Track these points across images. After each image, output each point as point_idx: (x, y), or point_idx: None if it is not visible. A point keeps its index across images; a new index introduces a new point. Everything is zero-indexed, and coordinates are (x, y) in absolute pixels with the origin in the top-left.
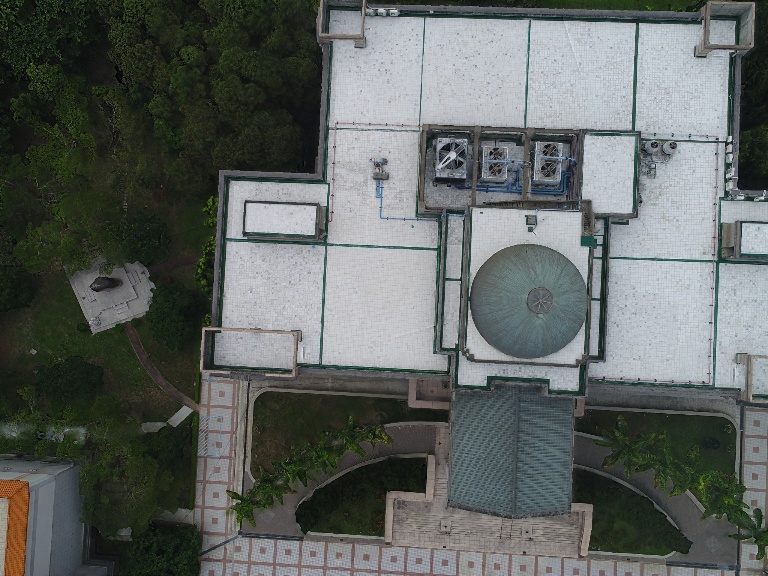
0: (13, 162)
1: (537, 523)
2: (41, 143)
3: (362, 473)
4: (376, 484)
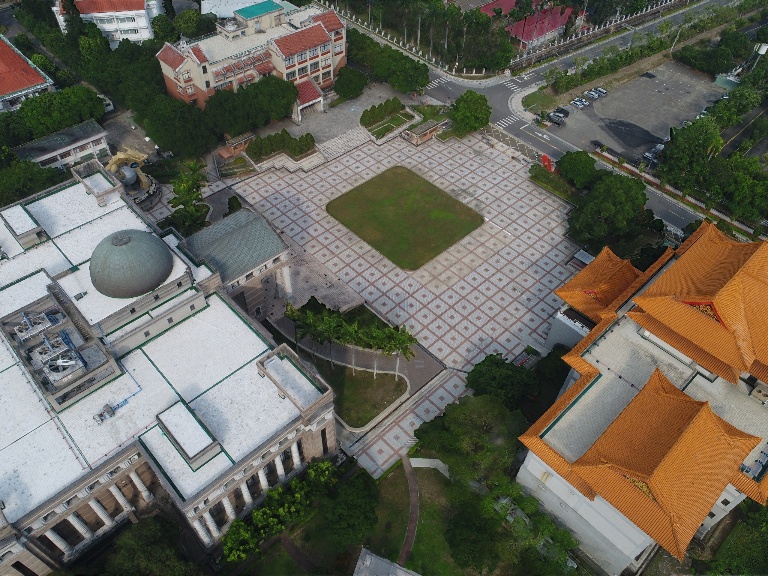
0: None
1: None
2: None
3: None
4: None
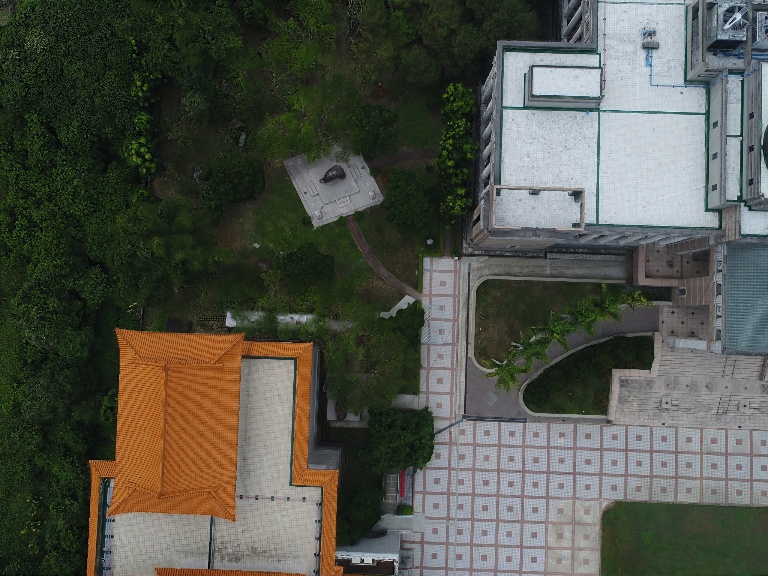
0: (250, 54)
1: (754, 397)
2: (257, 45)
3: (595, 349)
4: (612, 357)
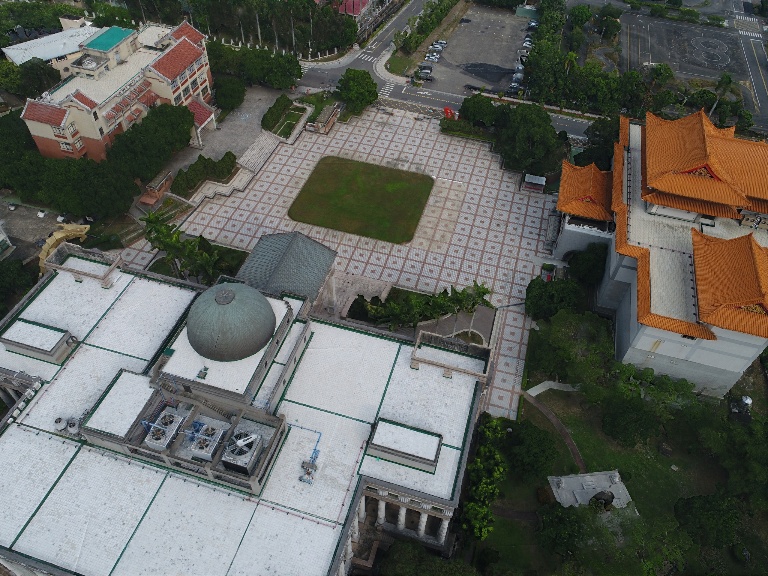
0: None
1: None
2: None
3: None
4: None
